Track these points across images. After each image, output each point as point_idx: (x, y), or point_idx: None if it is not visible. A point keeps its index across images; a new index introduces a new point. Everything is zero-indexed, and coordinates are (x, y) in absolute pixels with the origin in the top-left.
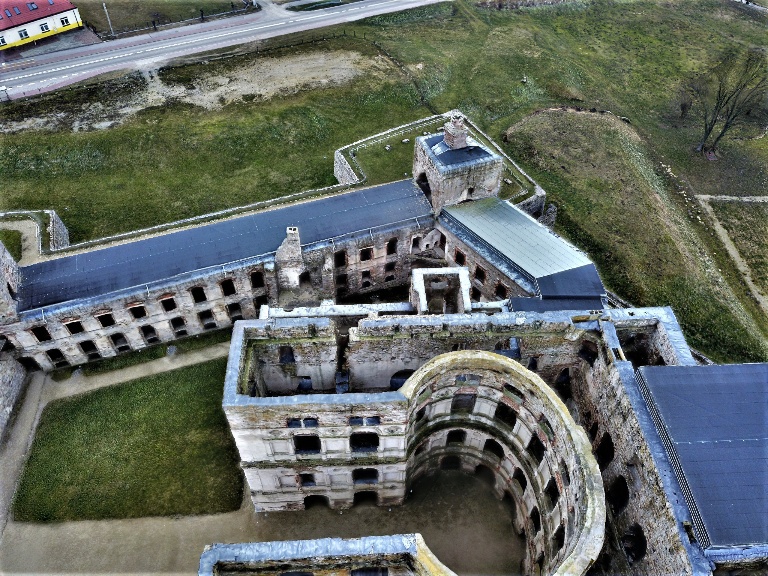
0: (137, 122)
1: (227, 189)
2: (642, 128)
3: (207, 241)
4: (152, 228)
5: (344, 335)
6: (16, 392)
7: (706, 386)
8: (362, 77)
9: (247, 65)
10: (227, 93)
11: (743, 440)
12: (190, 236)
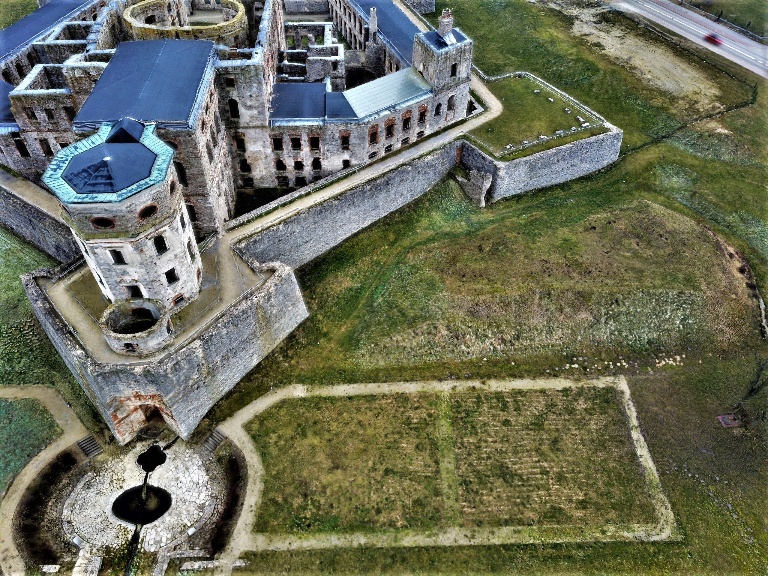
0: (539, 9)
1: (488, 53)
2: (764, 355)
3: (380, 5)
4: (423, 18)
5: (276, 5)
6: (316, 10)
7: (195, 54)
8: (669, 95)
9: (649, 42)
10: (598, 36)
11: (160, 54)
12: (385, 2)
